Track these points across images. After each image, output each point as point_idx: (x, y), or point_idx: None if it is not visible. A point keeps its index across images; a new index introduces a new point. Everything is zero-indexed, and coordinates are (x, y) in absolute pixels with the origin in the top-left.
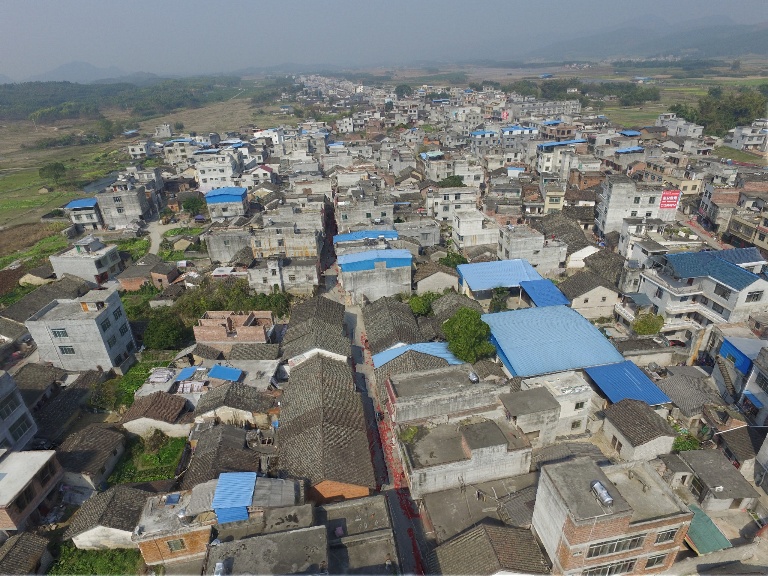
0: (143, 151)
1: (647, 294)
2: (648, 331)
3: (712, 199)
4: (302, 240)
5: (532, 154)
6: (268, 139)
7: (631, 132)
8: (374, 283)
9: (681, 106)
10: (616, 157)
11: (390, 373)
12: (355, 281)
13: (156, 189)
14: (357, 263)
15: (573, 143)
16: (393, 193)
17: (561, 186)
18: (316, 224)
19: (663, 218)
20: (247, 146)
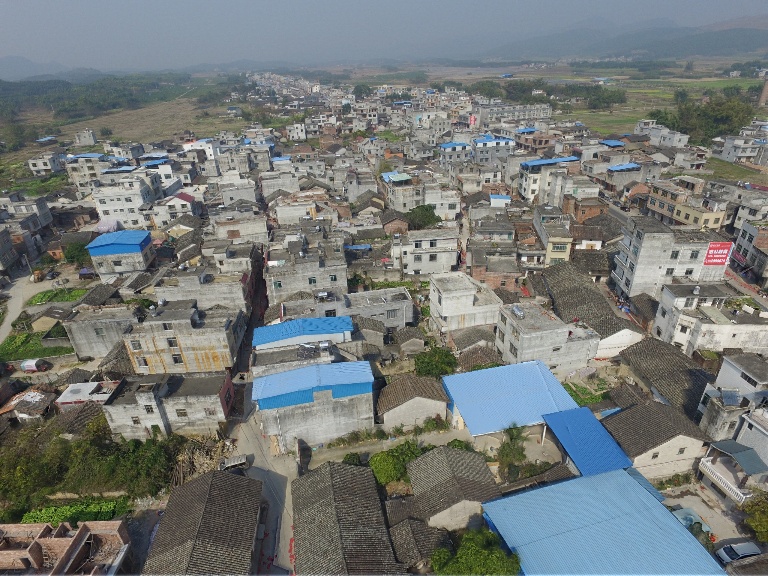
0: (48, 166)
1: (757, 451)
2: None
3: (755, 243)
4: (205, 337)
5: (513, 172)
6: (200, 152)
7: (614, 142)
8: (314, 421)
9: (661, 112)
10: (609, 175)
11: None
12: (283, 421)
13: (39, 225)
14: (284, 396)
15: (563, 162)
16: (349, 229)
17: (565, 227)
18: (235, 297)
19: (707, 277)
20: (170, 163)
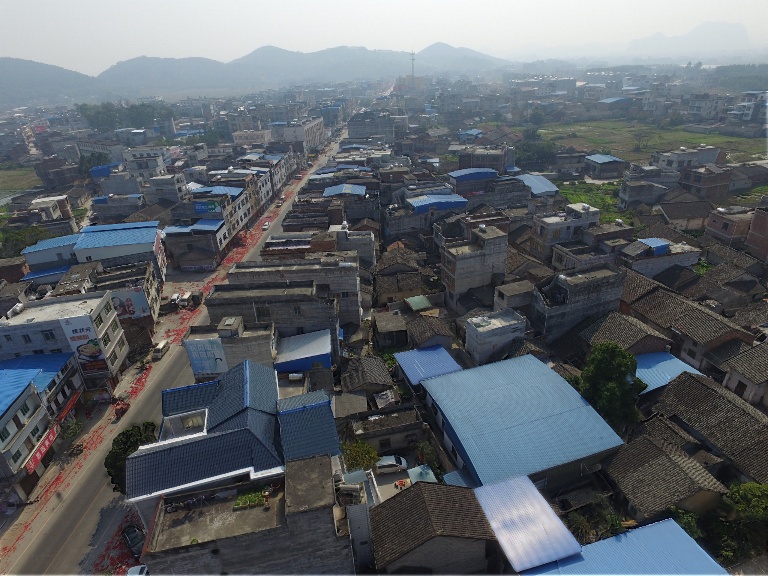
0: None
1: None
2: (365, 446)
3: None
4: None
5: None
6: None
7: None
8: None
9: None
10: None
11: (651, 330)
12: None
13: None
14: None
15: None
16: None
17: None
18: None
19: None
20: None
